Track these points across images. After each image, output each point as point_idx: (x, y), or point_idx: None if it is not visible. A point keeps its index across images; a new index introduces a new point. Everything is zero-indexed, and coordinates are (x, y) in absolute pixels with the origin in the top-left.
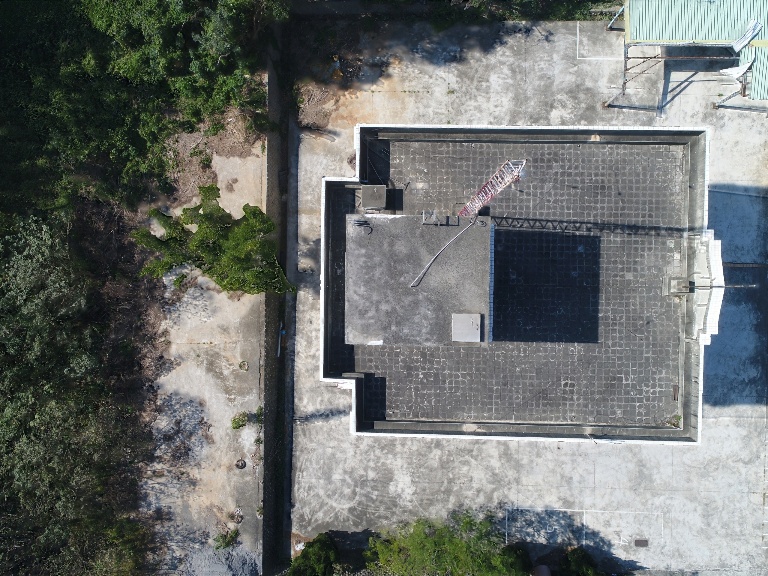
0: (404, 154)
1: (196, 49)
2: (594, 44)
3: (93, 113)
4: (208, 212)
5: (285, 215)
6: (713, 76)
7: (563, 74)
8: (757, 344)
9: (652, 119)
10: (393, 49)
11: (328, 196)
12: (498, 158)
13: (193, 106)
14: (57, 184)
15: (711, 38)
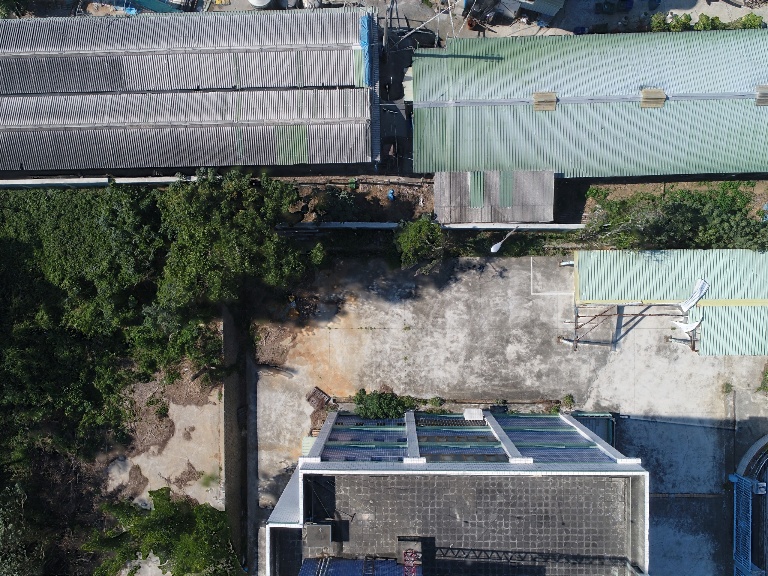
0: (349, 486)
1: (150, 303)
2: (548, 279)
3: (47, 368)
4: (158, 518)
5: (245, 450)
6: (666, 310)
7: (518, 309)
8: (715, 573)
9: (607, 353)
10: (349, 286)
11: (274, 534)
12: (443, 489)
13: (148, 356)
14: (13, 440)
15: (659, 298)
